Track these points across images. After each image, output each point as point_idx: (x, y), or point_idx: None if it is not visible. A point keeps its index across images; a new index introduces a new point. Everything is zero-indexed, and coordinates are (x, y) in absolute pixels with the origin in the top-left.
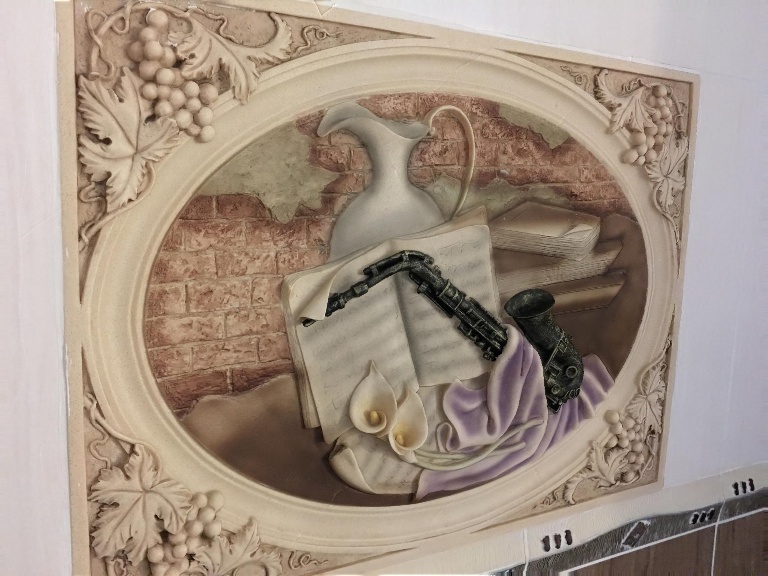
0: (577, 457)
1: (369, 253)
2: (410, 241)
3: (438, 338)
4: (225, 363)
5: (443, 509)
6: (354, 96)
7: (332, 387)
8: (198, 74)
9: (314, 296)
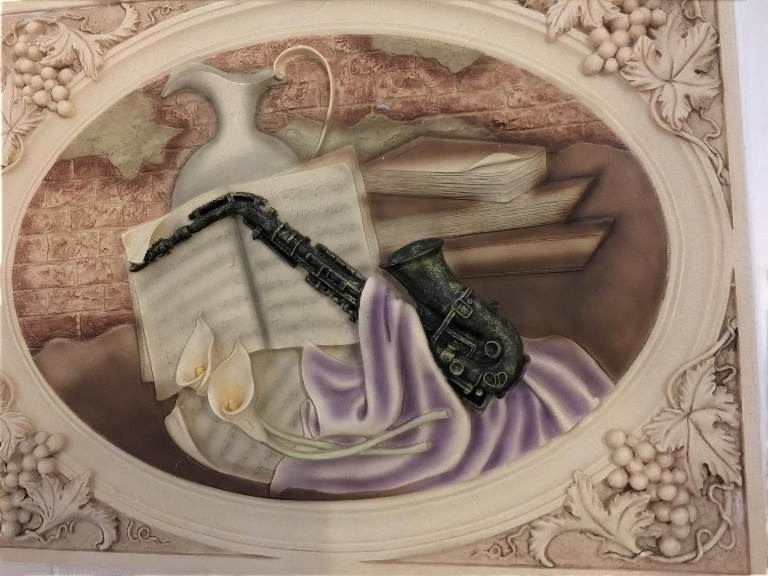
0: (547, 490)
1: (197, 198)
2: (244, 184)
3: (283, 292)
4: (75, 309)
5: (323, 519)
6: (200, 57)
7: (167, 339)
8: (57, 62)
9: None
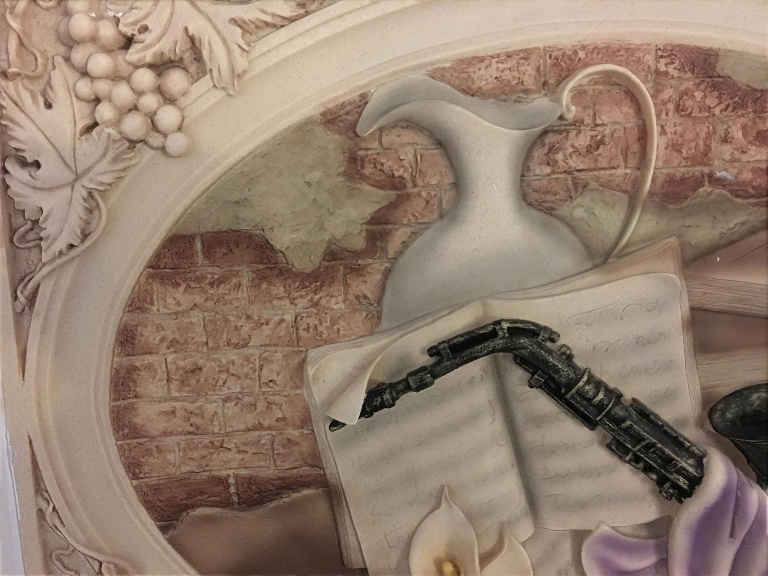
0: None
1: (439, 322)
2: (516, 303)
3: (569, 459)
4: (226, 466)
5: None
6: (422, 64)
7: (384, 516)
8: (156, 56)
9: (349, 384)
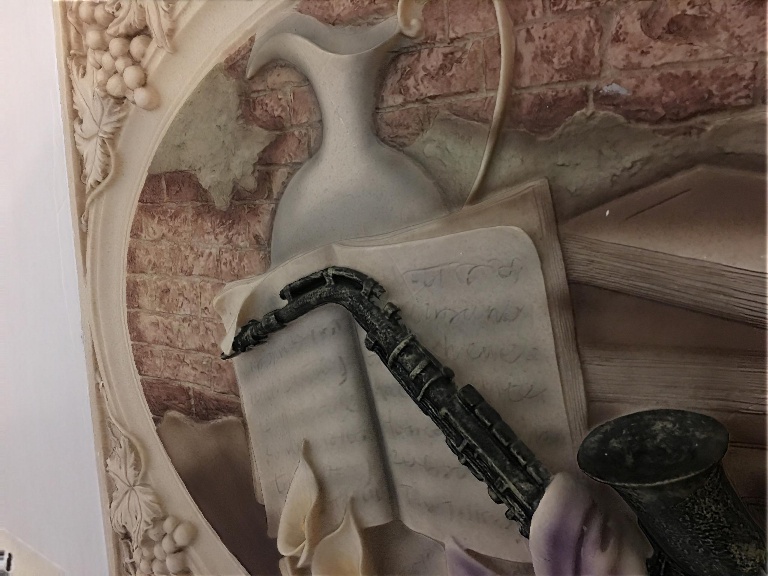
0: None
1: (290, 264)
2: (352, 250)
3: (414, 445)
4: (187, 379)
5: None
6: None
7: (275, 458)
8: (127, 27)
9: None
